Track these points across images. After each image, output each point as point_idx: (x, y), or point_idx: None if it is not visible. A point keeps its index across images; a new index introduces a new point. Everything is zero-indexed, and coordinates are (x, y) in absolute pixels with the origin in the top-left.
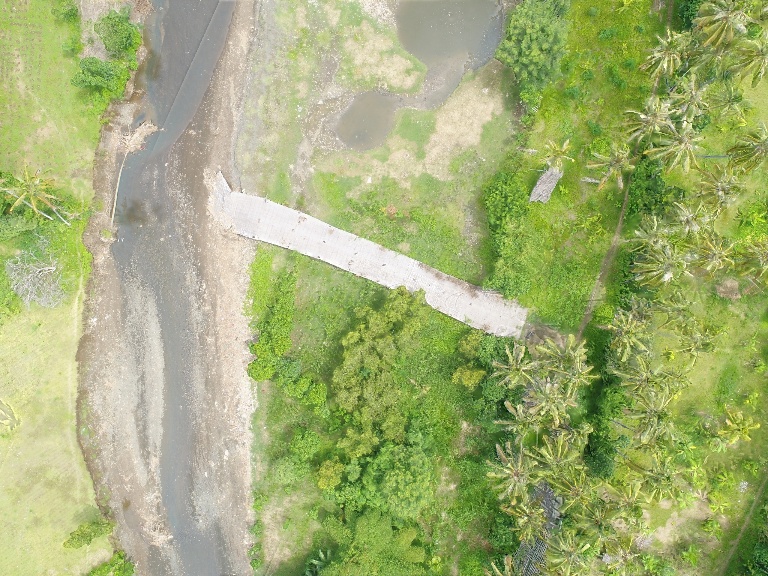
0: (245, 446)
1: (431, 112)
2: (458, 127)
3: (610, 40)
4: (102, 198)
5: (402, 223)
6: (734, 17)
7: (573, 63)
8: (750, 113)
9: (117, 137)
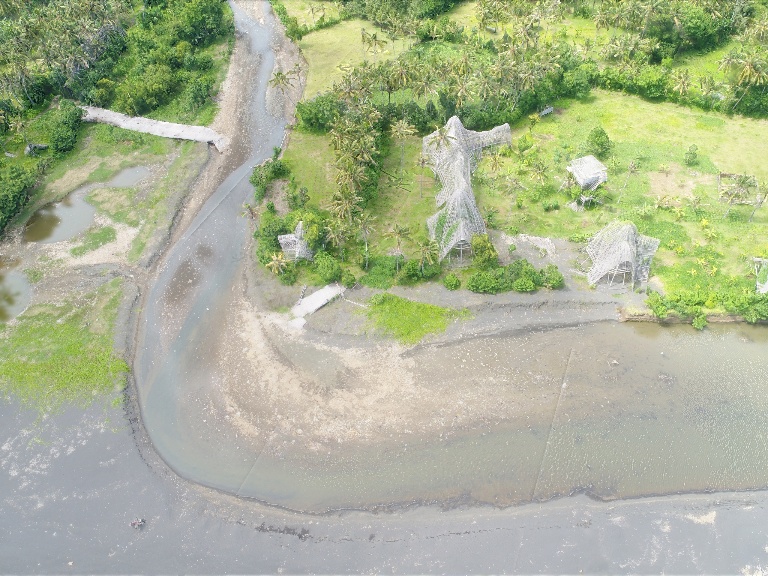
0: (230, 73)
1: (89, 181)
2: (76, 176)
3: None
4: None
5: None
6: None
7: None
8: None
9: None
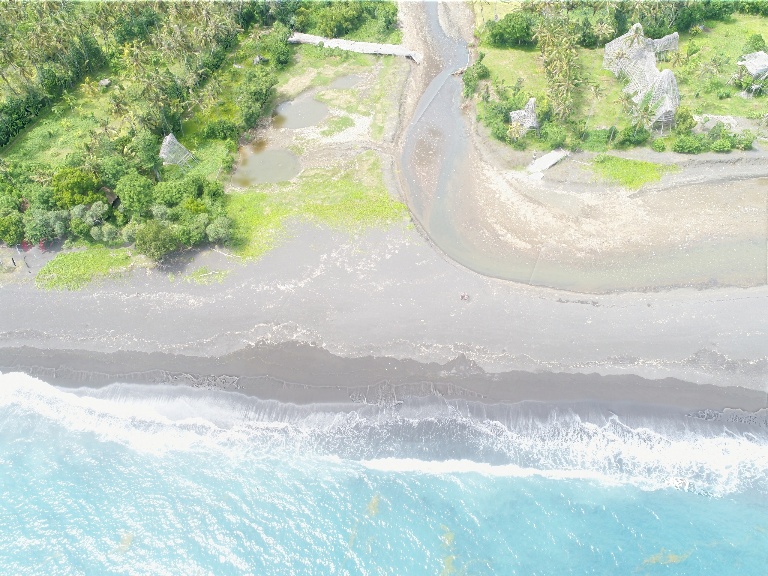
0: (401, 7)
1: (313, 85)
2: None
3: None
4: None
5: None
6: None
7: None
8: None
9: None
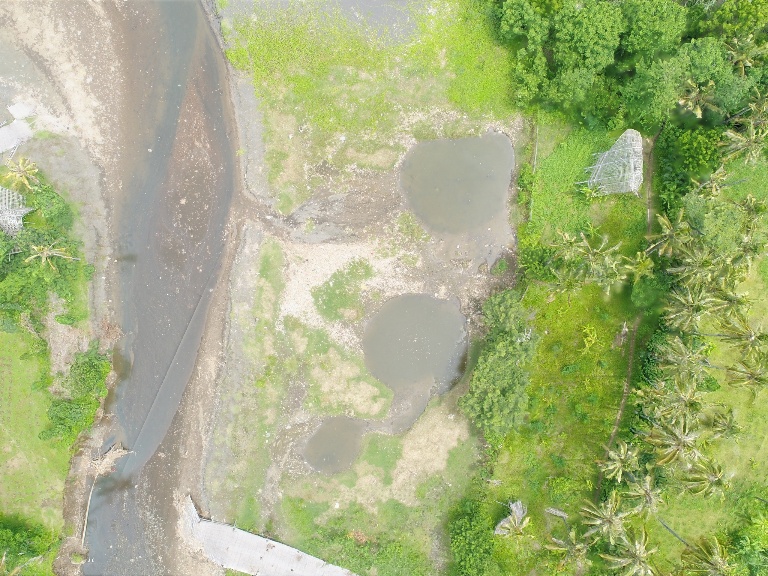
0: None
1: (398, 438)
2: (424, 453)
3: (573, 374)
4: (72, 522)
5: (369, 548)
6: (684, 455)
7: (536, 402)
8: (711, 446)
9: (87, 460)
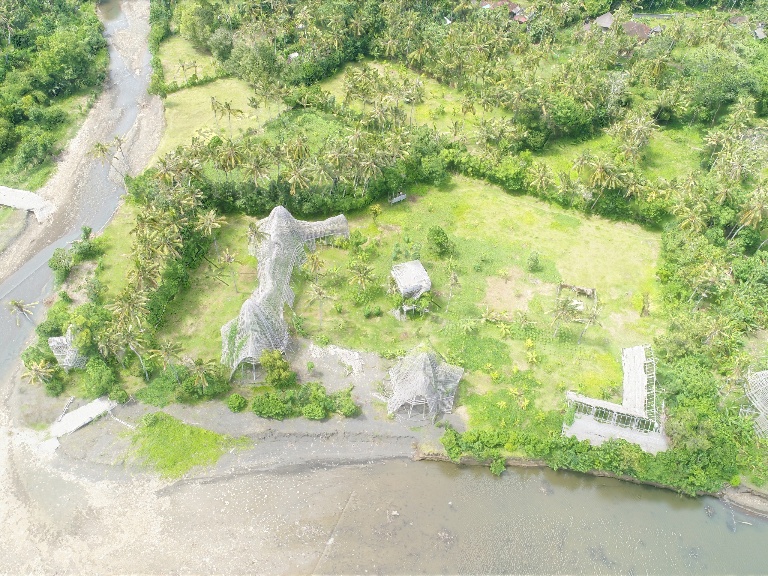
0: (84, 129)
1: None
2: None
3: None
4: None
5: None
6: None
7: None
8: None
9: None
